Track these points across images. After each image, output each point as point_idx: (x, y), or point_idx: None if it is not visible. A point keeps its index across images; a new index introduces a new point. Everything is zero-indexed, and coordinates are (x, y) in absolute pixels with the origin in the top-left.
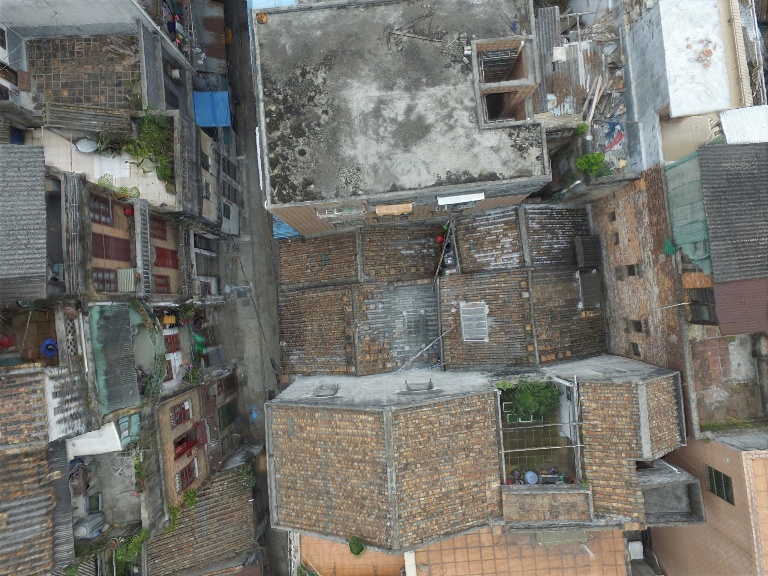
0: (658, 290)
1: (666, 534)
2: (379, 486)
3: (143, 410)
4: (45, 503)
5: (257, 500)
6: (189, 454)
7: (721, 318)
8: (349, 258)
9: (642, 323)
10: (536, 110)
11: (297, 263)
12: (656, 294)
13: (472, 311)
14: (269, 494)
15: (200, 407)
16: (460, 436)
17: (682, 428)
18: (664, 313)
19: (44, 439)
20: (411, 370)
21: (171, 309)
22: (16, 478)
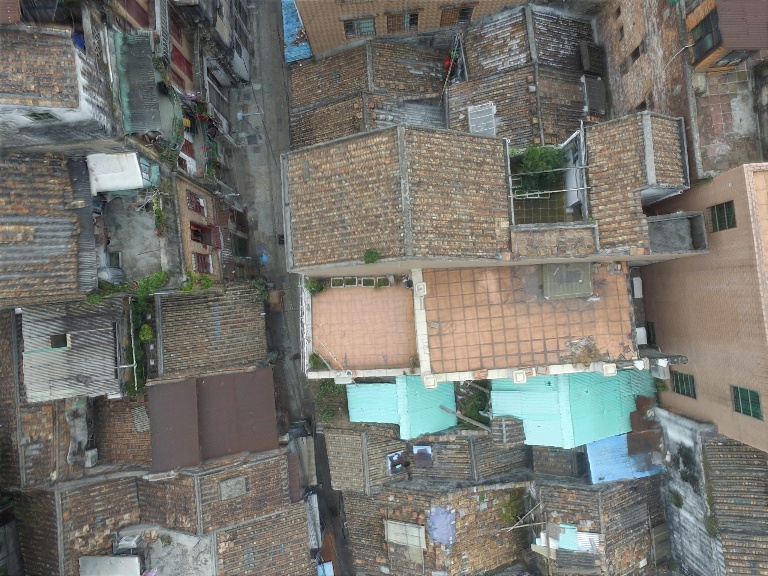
0: (662, 52)
1: (669, 315)
2: (393, 201)
3: (162, 166)
4: (70, 226)
5: (268, 335)
6: (204, 246)
7: (724, 33)
8: (359, 71)
9: (646, 101)
10: None
11: (308, 85)
12: (660, 58)
13: (480, 114)
14: (285, 239)
15: (214, 215)
16: (470, 172)
17: (685, 171)
18: (668, 71)
19: (75, 99)
20: None
21: (186, 112)
22: (42, 196)
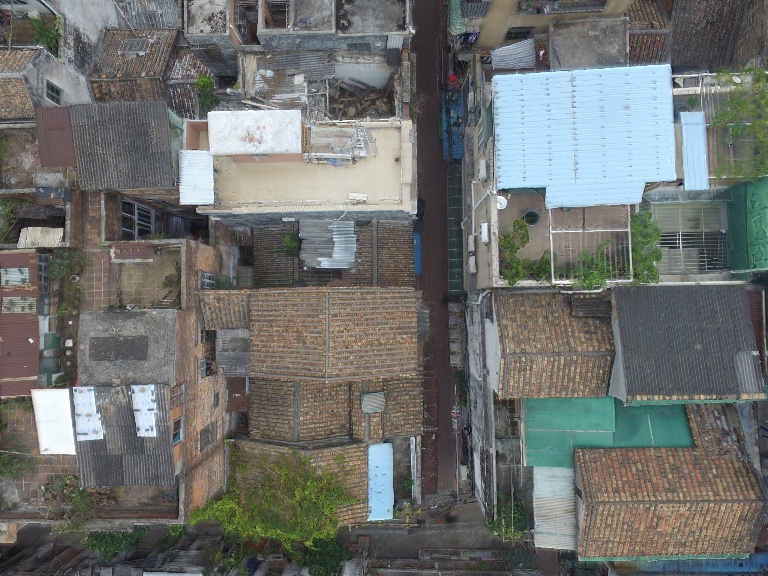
0: None
1: None
2: None
3: None
4: None
5: None
6: None
7: (47, 110)
8: None
9: None
10: (260, 61)
11: None
12: None
13: None
14: None
15: None
16: None
17: None
18: None
19: None
20: (107, 1)
21: None
22: None
